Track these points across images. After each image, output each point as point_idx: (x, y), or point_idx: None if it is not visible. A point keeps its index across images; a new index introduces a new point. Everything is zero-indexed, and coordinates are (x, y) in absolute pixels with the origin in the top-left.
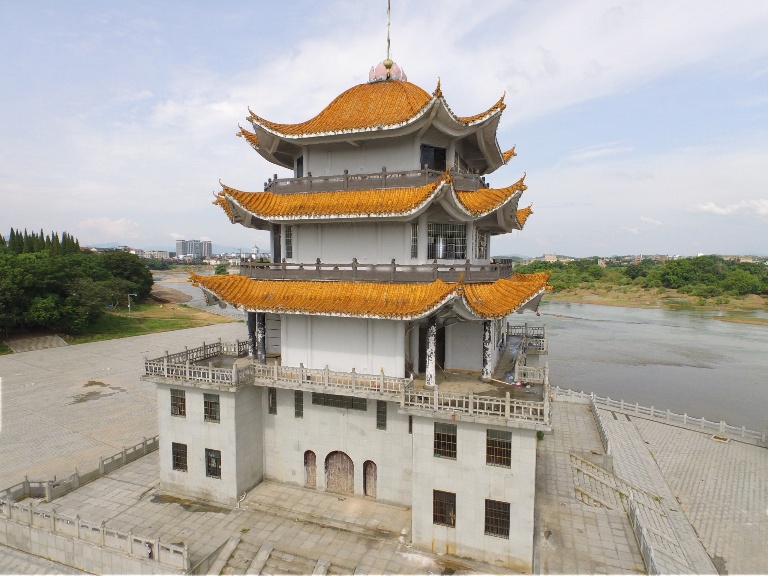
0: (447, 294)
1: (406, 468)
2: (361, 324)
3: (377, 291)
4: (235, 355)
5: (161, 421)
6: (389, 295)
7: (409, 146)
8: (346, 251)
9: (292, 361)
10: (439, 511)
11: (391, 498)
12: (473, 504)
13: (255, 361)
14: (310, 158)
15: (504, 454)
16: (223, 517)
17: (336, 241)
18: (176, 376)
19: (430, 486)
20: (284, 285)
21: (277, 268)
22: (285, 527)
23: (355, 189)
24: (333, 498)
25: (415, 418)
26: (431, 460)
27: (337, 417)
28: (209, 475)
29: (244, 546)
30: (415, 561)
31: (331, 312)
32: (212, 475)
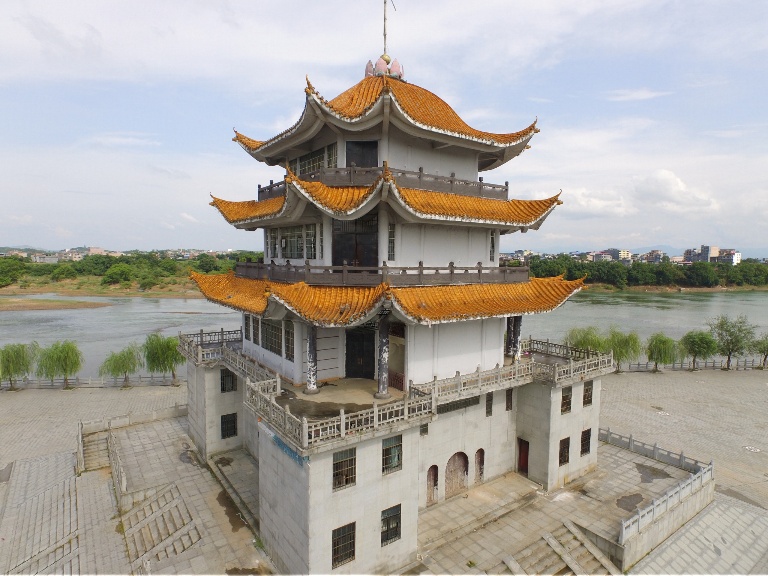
0: (574, 289)
1: (503, 442)
2: (478, 324)
3: (503, 291)
4: (277, 396)
5: (315, 509)
6: (512, 294)
7: (472, 160)
8: (445, 254)
9: (418, 375)
10: (562, 455)
11: (493, 474)
12: (577, 439)
13: (329, 393)
14: (390, 148)
15: (590, 396)
16: (432, 573)
17: (437, 243)
18: (358, 429)
19: (559, 439)
20: (427, 291)
21: (414, 273)
22: (482, 540)
23: (463, 194)
24: (460, 500)
25: (554, 390)
26: (560, 418)
27: (457, 419)
28: (385, 543)
29: (493, 573)
30: (566, 498)
31: (504, 313)
32: (386, 541)
